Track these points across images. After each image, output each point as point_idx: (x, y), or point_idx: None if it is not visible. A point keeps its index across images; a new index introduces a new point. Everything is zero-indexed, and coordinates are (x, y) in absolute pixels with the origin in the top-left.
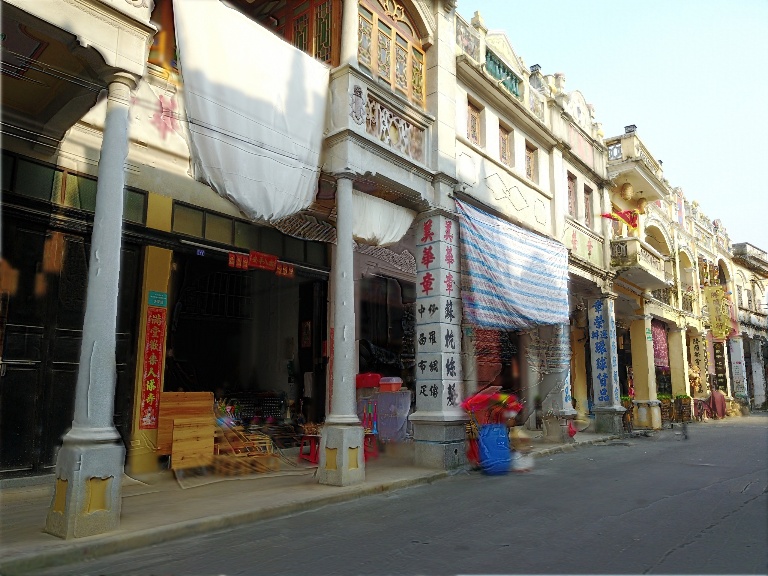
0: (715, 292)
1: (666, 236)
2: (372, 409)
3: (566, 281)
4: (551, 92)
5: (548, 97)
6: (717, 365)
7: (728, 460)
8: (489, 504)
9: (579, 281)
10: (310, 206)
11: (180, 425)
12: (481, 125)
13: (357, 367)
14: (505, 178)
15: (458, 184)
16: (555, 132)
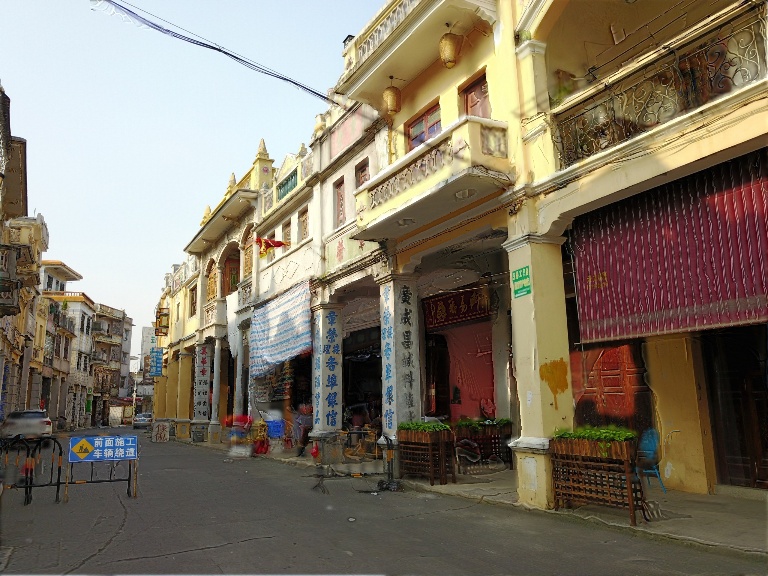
0: None
1: None
2: None
3: (305, 313)
4: None
5: None
6: None
7: None
8: None
9: None
10: None
11: None
12: None
13: None
14: None
15: None
16: (314, 171)
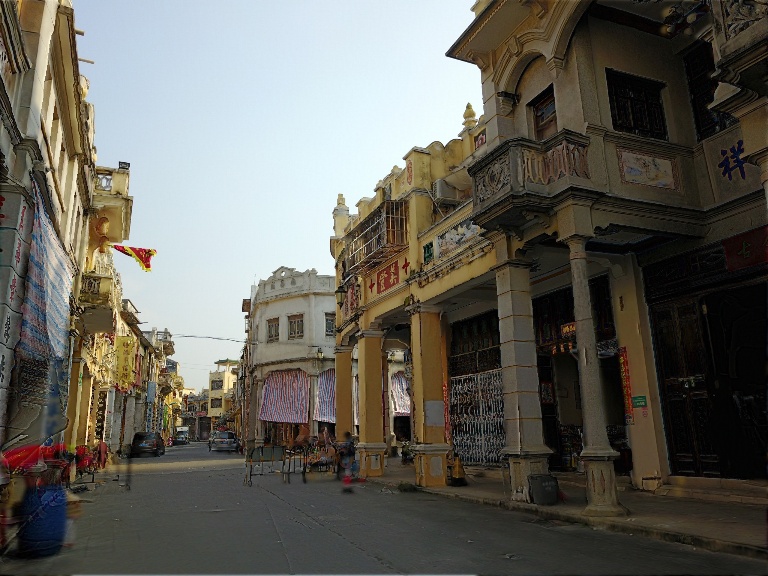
0: None
1: None
2: None
3: None
4: None
5: None
6: None
7: (220, 504)
8: None
9: None
10: None
11: None
12: None
13: None
14: None
15: (40, 162)
16: None
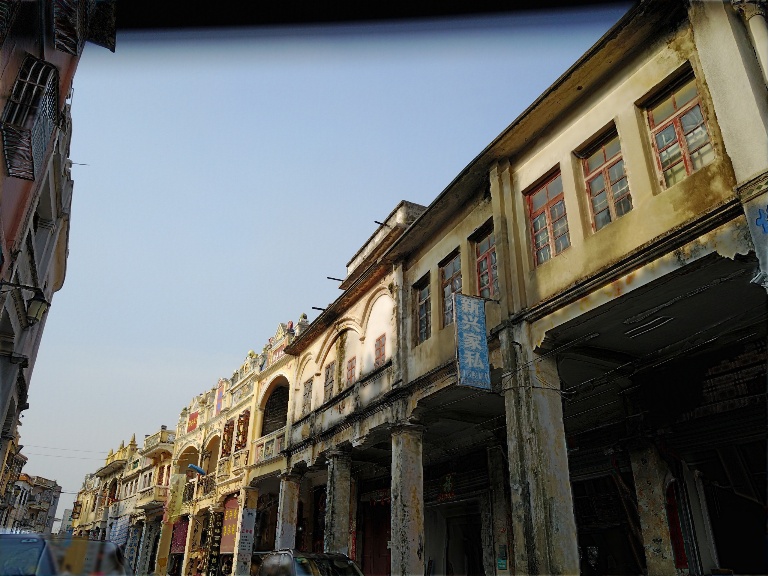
0: None
1: (195, 445)
2: None
3: (126, 528)
4: None
5: None
6: None
7: None
8: None
9: None
10: None
11: None
12: None
13: None
14: None
15: None
16: None
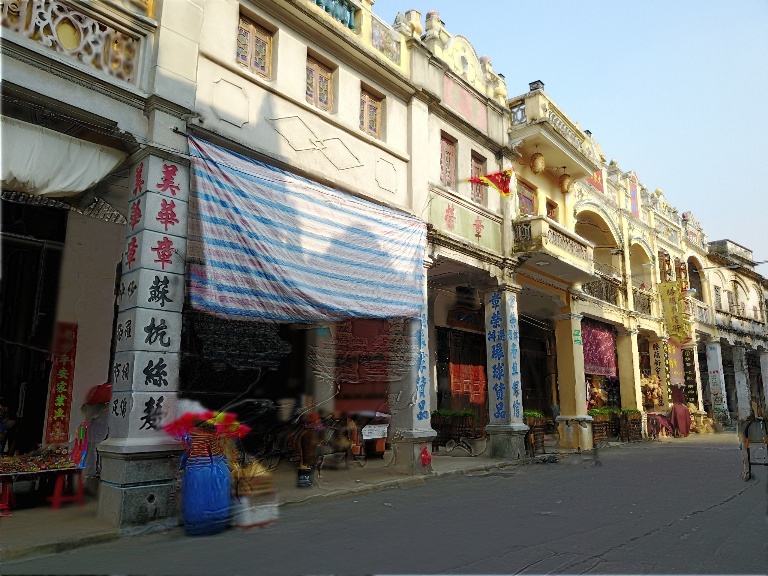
0: (671, 289)
1: (610, 224)
2: (83, 433)
3: (420, 264)
4: (414, 31)
5: (407, 36)
6: (687, 375)
7: (594, 503)
8: None
9: (466, 269)
10: None
11: None
12: (273, 52)
13: (105, 375)
14: (316, 125)
15: (193, 115)
16: (416, 79)
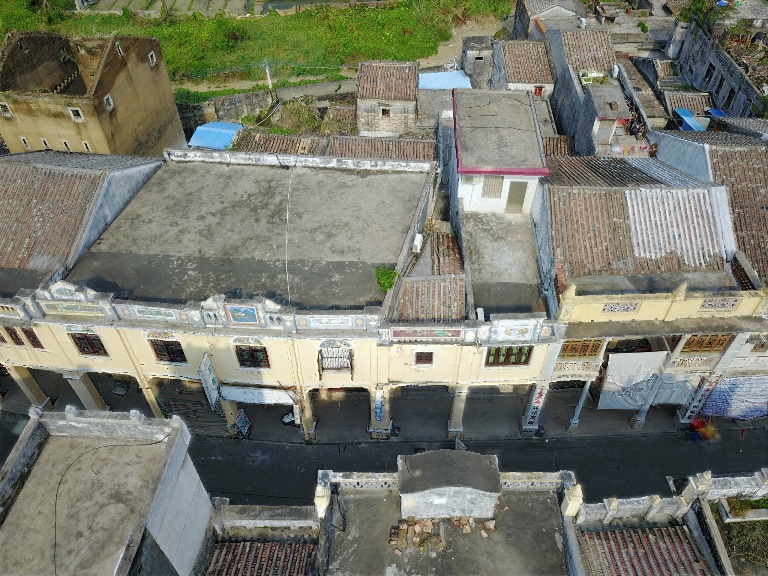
0: None
1: None
2: None
3: None
4: None
5: None
6: None
7: None
8: (655, 461)
9: None
10: (648, 378)
11: (605, 387)
12: None
13: None
14: None
15: None
16: None
